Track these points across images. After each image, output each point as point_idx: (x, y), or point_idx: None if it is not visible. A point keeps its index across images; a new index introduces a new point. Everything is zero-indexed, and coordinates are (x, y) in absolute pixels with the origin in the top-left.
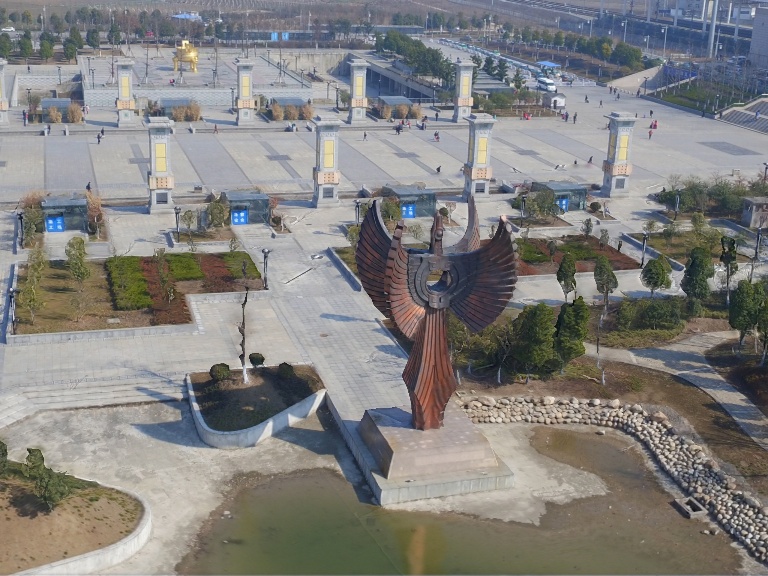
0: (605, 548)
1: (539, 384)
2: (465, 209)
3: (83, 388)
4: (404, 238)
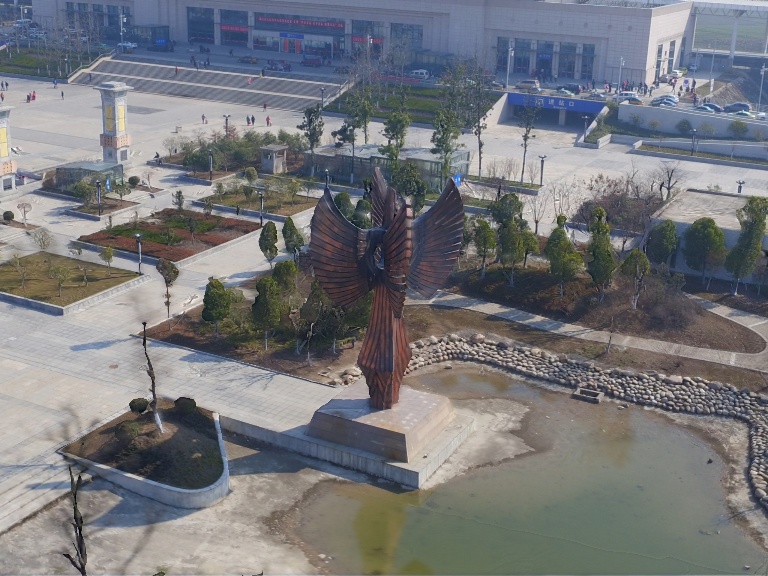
0: (595, 446)
1: (361, 344)
2: (8, 210)
3: None
4: (5, 252)
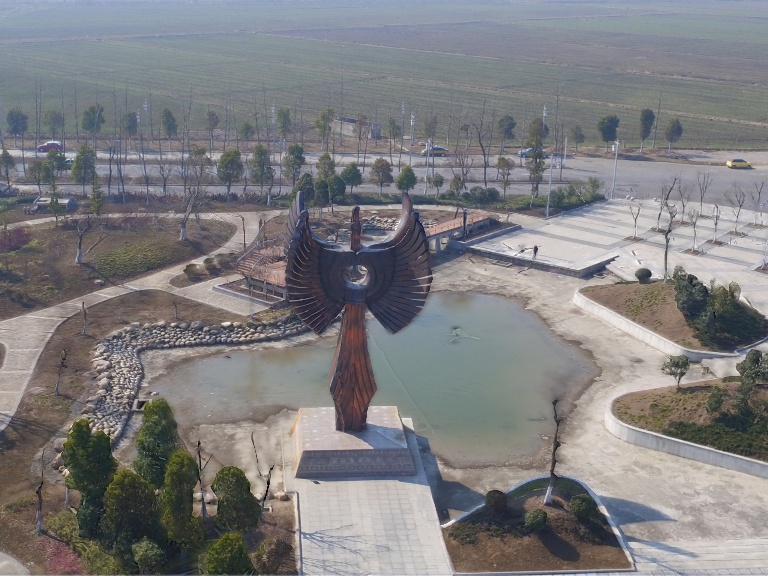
0: (247, 392)
1: None
2: None
3: (767, 558)
4: None
